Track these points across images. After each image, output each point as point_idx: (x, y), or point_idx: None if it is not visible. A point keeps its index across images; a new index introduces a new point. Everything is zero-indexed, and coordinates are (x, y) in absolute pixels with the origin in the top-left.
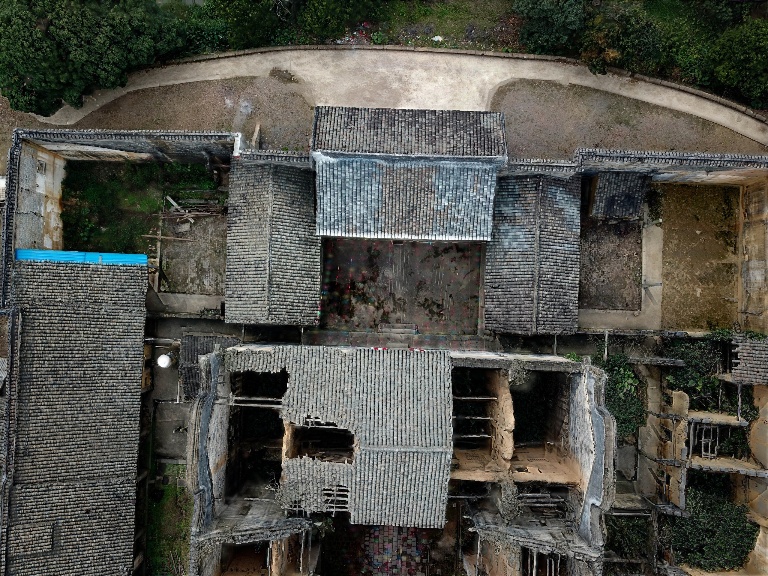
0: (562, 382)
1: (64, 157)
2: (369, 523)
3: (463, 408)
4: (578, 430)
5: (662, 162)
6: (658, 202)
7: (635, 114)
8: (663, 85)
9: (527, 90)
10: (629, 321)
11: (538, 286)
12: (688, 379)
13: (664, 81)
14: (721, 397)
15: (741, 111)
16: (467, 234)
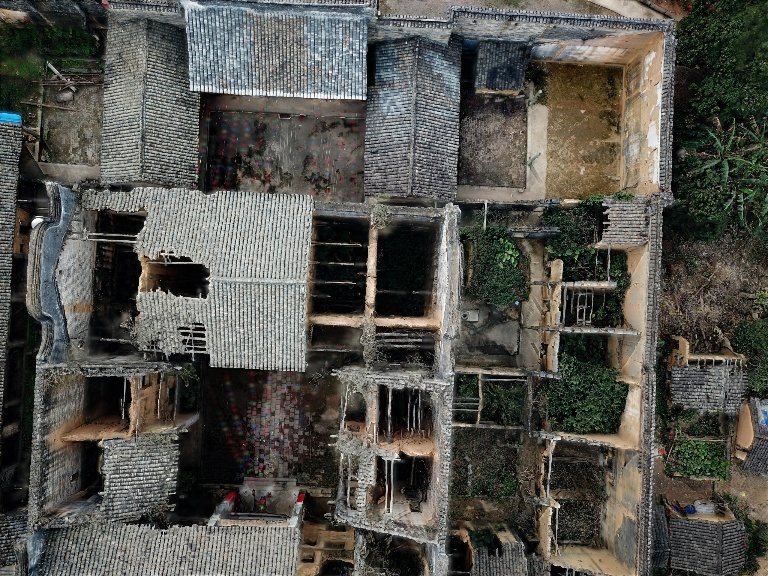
0: (434, 240)
1: None
2: (229, 366)
3: (342, 274)
4: (441, 276)
5: (533, 21)
6: (544, 81)
7: None
8: None
9: None
10: (514, 198)
11: (414, 148)
12: (565, 248)
13: None
14: (598, 267)
15: None
16: (342, 93)
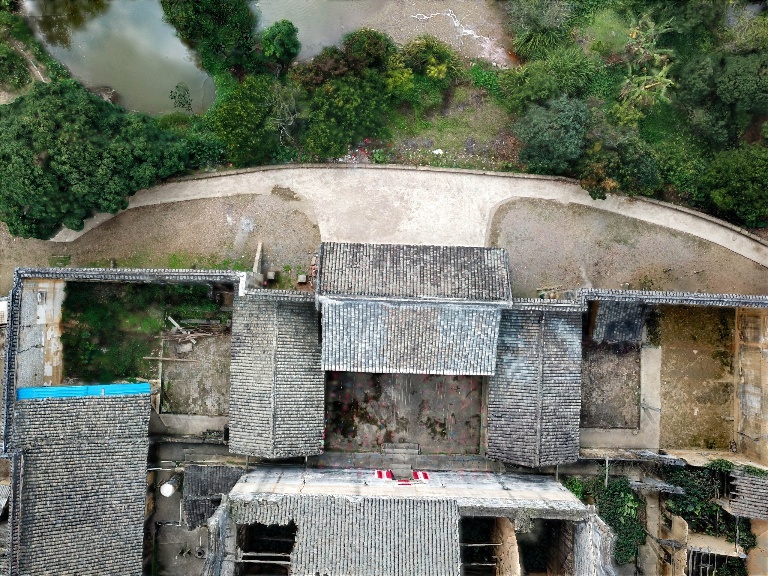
0: None
1: (64, 280)
2: None
3: (466, 535)
4: (582, 575)
5: (663, 302)
6: (656, 322)
7: (633, 233)
8: (661, 205)
9: (528, 209)
10: (628, 440)
11: (541, 418)
12: (687, 504)
13: (662, 201)
14: (718, 520)
15: (736, 231)
16: (471, 369)
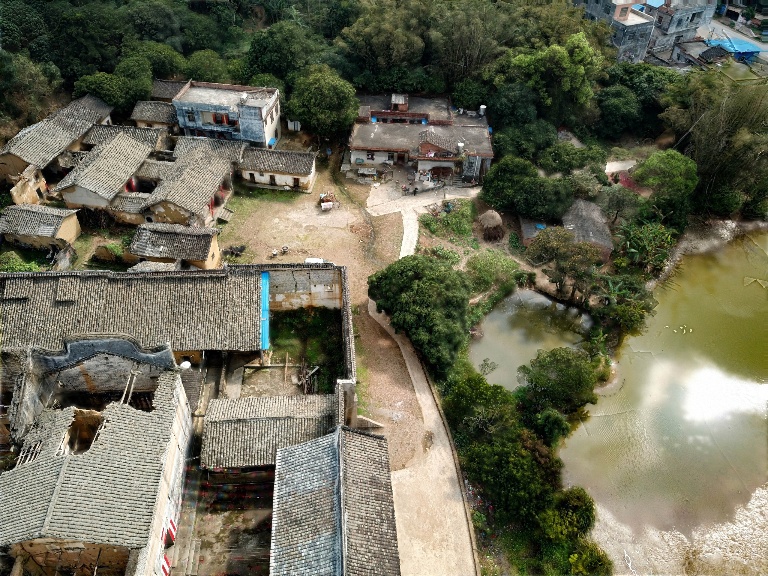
0: None
1: None
2: None
3: None
4: None
5: None
6: None
7: None
8: None
9: None
10: None
11: None
12: None
13: None
14: None
15: None
16: None
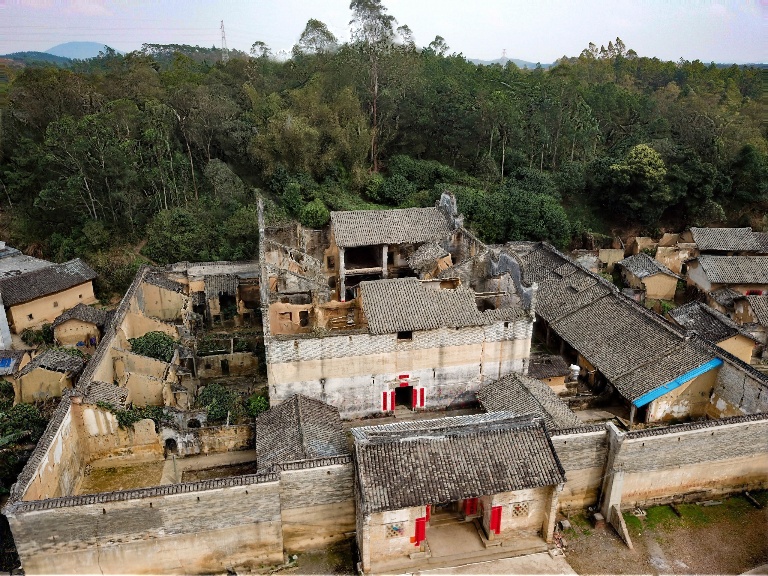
0: None
1: None
2: None
3: None
4: None
5: None
6: None
7: None
8: None
9: None
10: (196, 462)
11: None
12: None
13: None
14: None
15: None
16: None
